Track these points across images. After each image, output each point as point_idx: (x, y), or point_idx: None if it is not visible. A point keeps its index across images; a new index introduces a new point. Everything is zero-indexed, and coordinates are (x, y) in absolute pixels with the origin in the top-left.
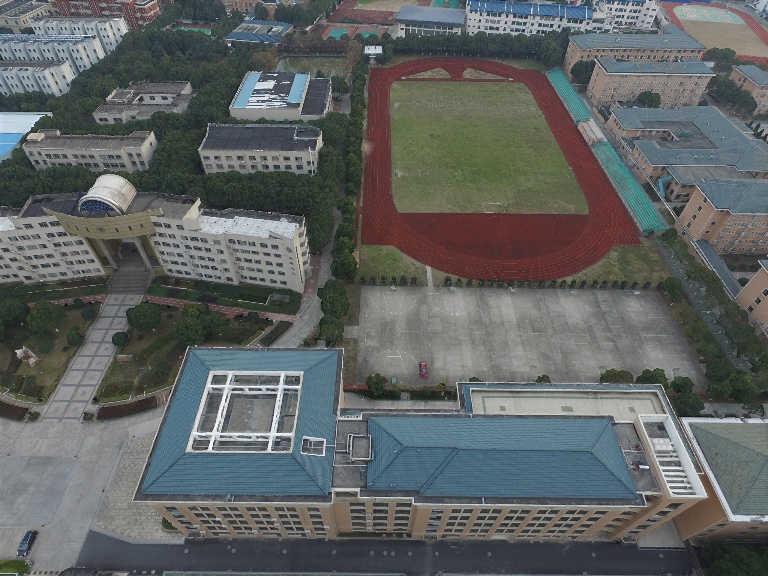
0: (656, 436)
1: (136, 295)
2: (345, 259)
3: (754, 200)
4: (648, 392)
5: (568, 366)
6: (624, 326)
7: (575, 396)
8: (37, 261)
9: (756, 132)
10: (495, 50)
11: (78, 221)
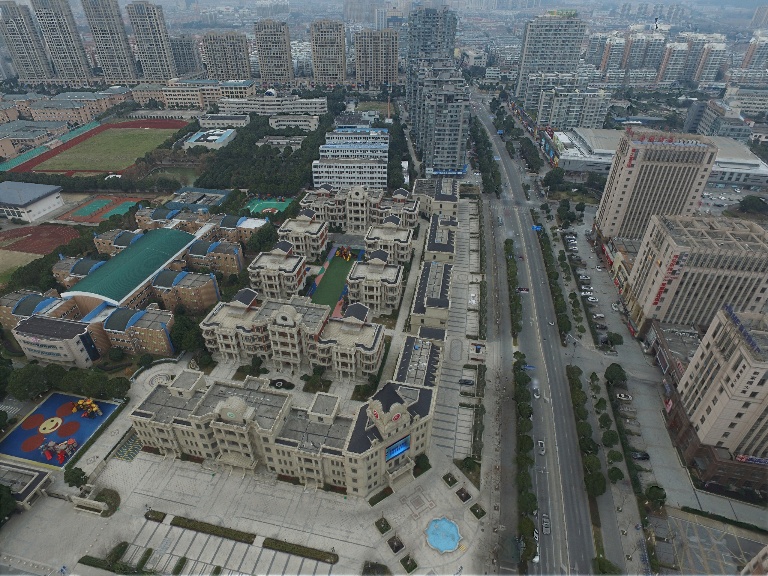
0: None
1: None
2: None
3: None
4: None
5: None
6: None
7: None
8: None
9: None
10: None
11: (278, 95)
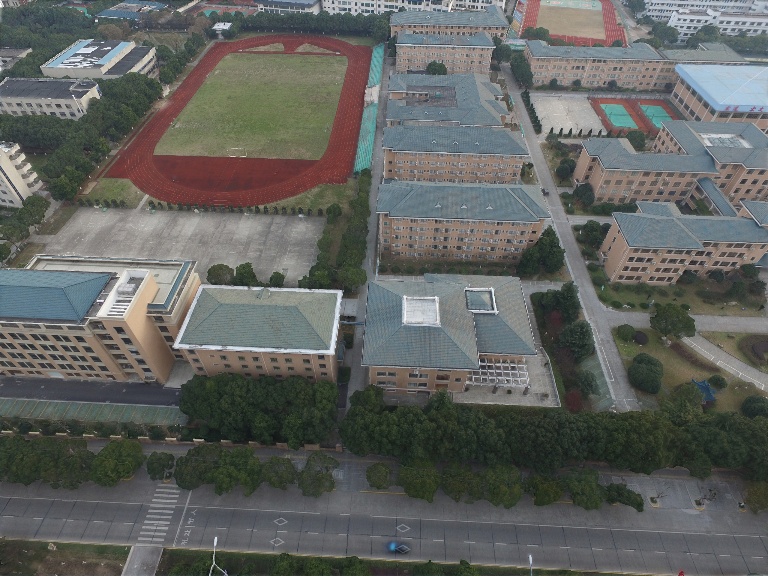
0: (138, 286)
1: None
2: (58, 182)
3: (414, 140)
4: (179, 264)
5: (208, 268)
6: (279, 242)
7: (120, 266)
8: None
9: (525, 99)
10: (335, 28)
11: None
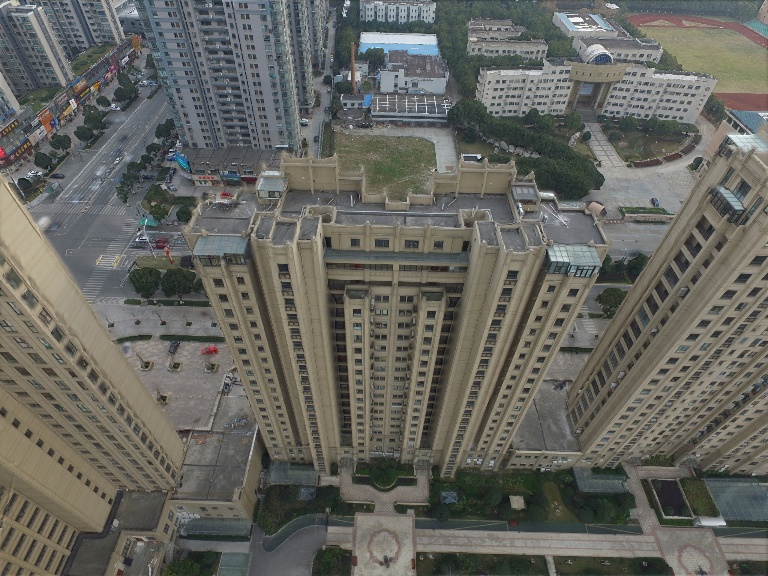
0: None
1: (593, 123)
2: (723, 103)
3: None
4: None
5: None
6: None
7: None
8: (538, 100)
9: None
10: (700, 8)
11: (590, 68)
